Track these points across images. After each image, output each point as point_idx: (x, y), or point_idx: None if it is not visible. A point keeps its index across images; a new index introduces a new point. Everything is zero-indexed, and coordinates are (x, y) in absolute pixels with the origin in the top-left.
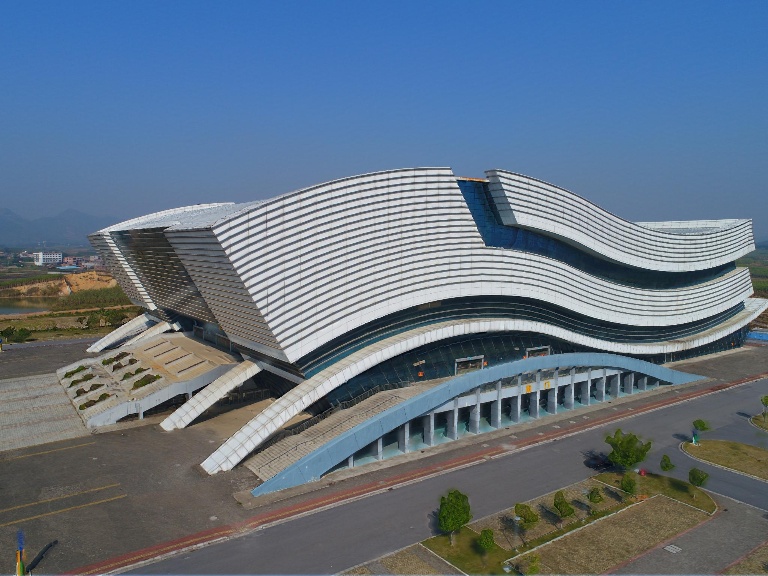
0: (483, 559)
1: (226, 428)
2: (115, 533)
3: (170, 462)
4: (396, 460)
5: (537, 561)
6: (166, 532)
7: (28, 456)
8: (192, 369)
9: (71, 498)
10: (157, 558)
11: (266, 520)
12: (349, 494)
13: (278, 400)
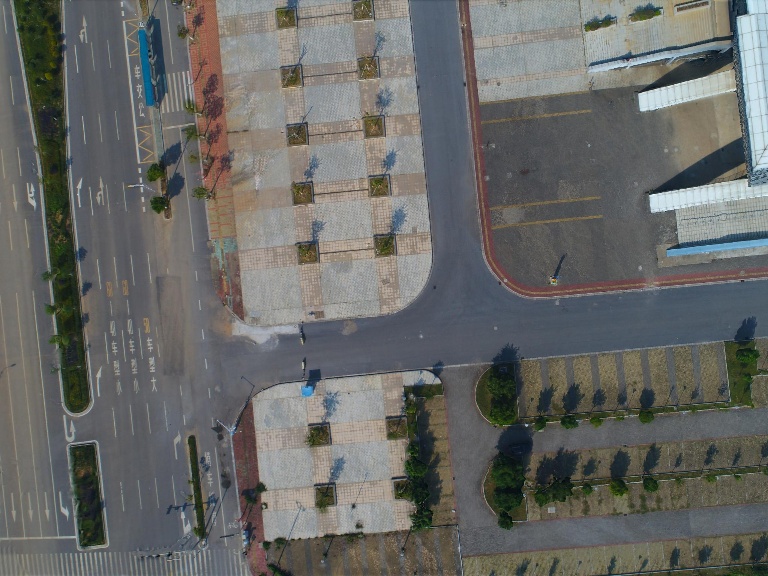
0: (742, 370)
1: (683, 125)
2: (593, 260)
3: (633, 177)
4: (767, 248)
5: (764, 383)
6: (616, 271)
7: (549, 117)
8: (691, 10)
9: (574, 205)
10: (608, 292)
11: (664, 283)
12: (717, 277)
13: (724, 184)
